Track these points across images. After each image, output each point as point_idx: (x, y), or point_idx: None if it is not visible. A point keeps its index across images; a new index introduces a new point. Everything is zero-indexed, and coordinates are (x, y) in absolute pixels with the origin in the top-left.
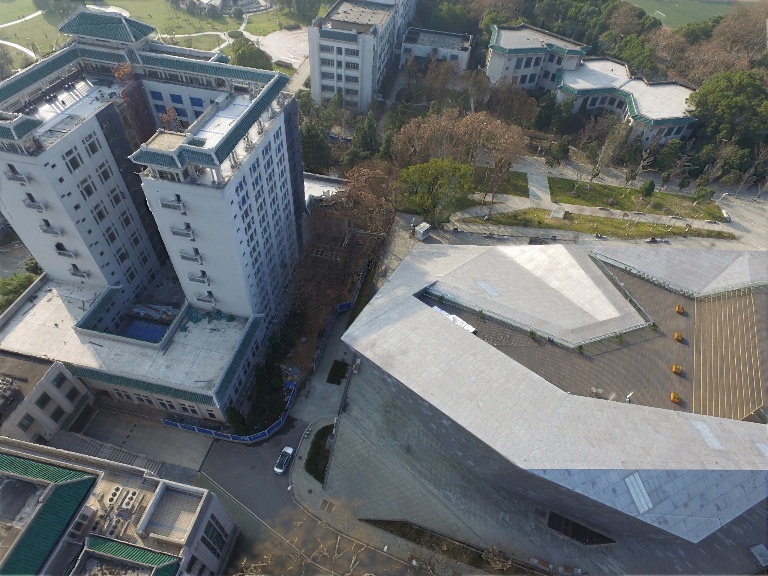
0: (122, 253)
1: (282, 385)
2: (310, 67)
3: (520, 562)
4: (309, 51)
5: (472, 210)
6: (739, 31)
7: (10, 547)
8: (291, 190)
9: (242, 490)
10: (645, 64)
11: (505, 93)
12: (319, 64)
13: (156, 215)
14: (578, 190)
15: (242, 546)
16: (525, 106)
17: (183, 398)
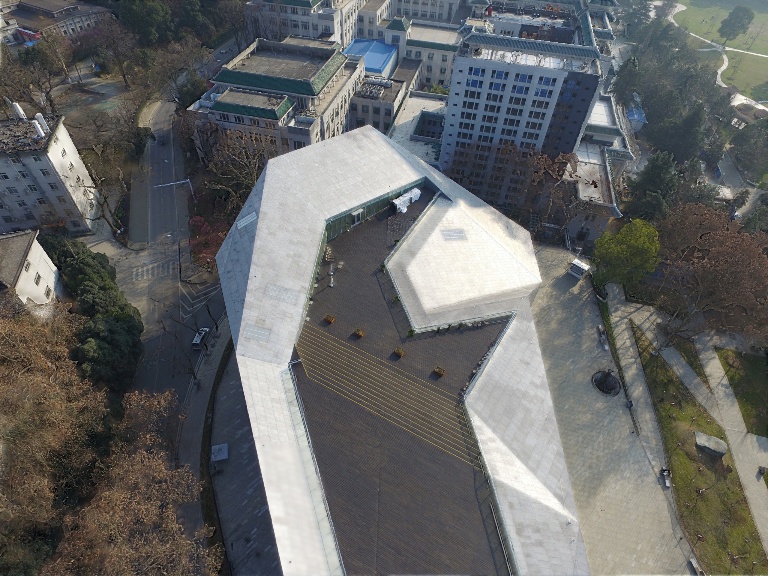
0: None
1: None
2: None
3: None
4: None
5: None
6: None
7: (289, 78)
8: (544, 141)
9: None
10: None
11: None
12: None
13: None
14: None
15: None
16: None
17: None
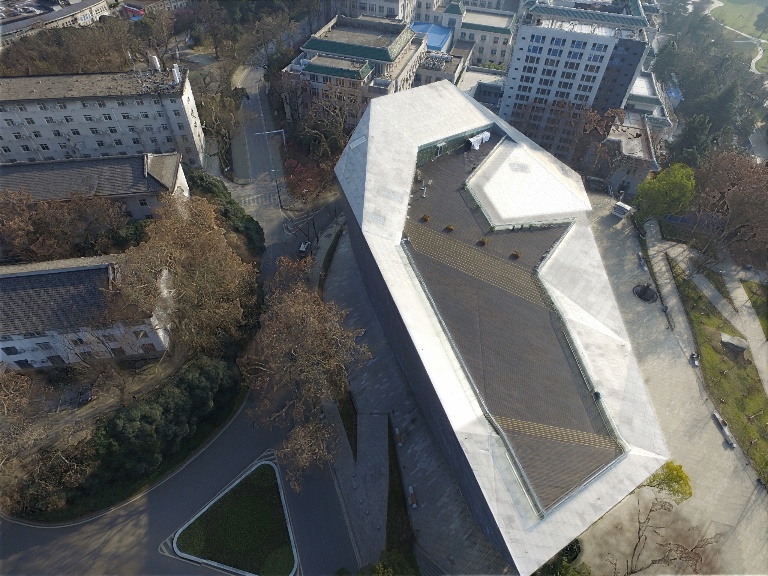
0: None
1: None
2: None
3: None
4: None
5: None
6: None
7: (369, 46)
8: (593, 102)
9: None
10: None
11: None
12: None
13: None
14: None
15: None
16: None
17: None
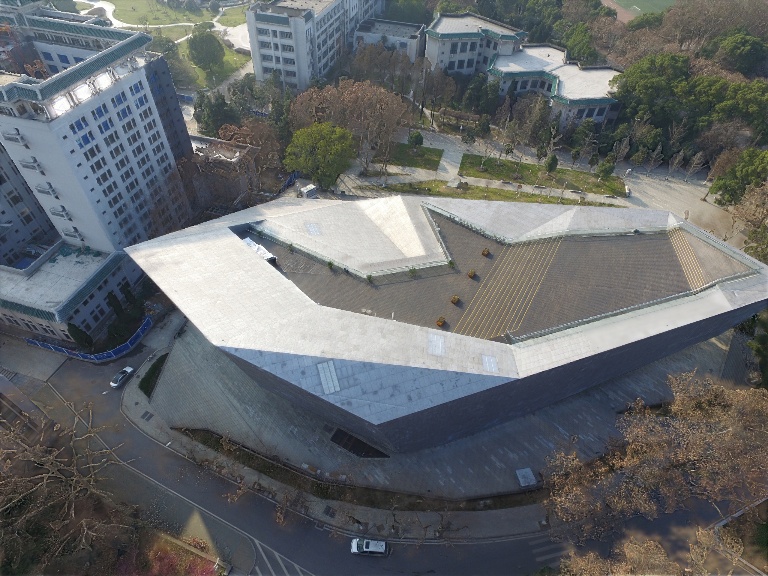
0: (15, 196)
1: (142, 317)
2: (251, 50)
3: (292, 466)
4: (249, 34)
5: (374, 179)
6: (690, 19)
7: None
8: (168, 145)
9: (78, 399)
10: (584, 50)
11: (425, 73)
12: (258, 47)
13: (8, 149)
14: (488, 165)
15: (61, 442)
16: (444, 85)
17: (31, 314)
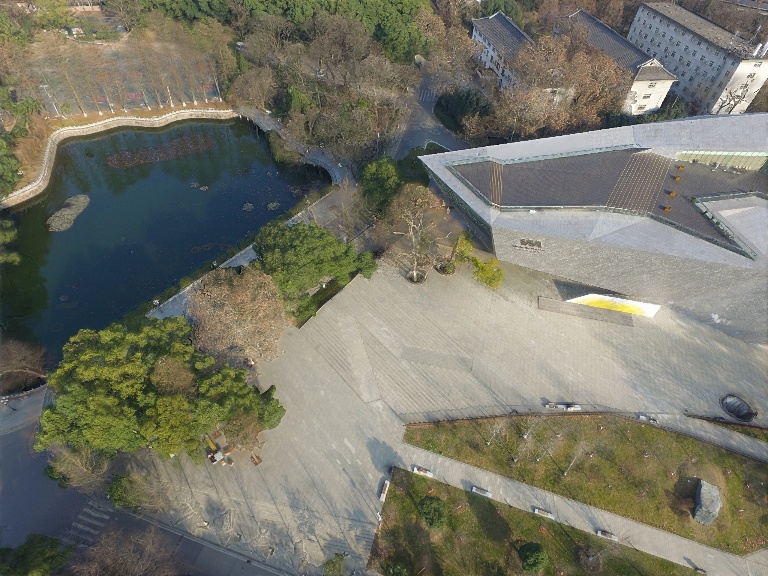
0: None
1: None
2: None
3: None
4: None
5: None
6: None
7: None
8: None
9: None
10: None
11: None
12: None
13: None
14: None
15: None
16: None
17: None
